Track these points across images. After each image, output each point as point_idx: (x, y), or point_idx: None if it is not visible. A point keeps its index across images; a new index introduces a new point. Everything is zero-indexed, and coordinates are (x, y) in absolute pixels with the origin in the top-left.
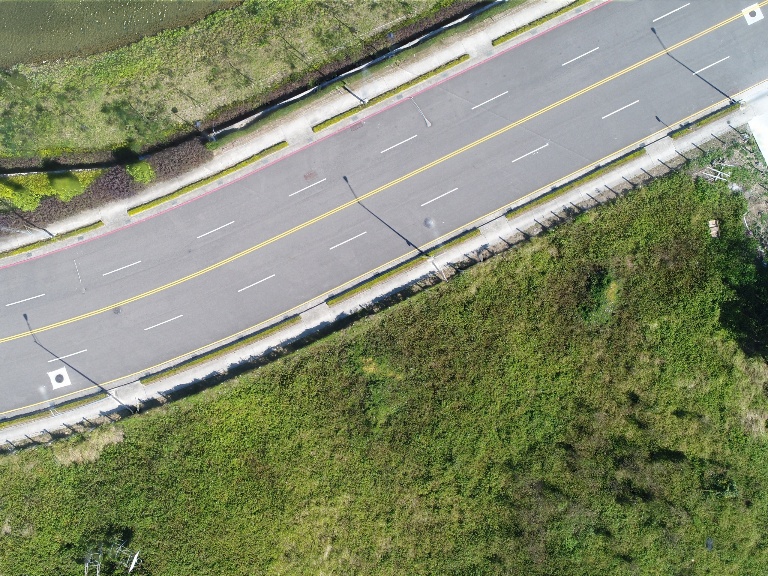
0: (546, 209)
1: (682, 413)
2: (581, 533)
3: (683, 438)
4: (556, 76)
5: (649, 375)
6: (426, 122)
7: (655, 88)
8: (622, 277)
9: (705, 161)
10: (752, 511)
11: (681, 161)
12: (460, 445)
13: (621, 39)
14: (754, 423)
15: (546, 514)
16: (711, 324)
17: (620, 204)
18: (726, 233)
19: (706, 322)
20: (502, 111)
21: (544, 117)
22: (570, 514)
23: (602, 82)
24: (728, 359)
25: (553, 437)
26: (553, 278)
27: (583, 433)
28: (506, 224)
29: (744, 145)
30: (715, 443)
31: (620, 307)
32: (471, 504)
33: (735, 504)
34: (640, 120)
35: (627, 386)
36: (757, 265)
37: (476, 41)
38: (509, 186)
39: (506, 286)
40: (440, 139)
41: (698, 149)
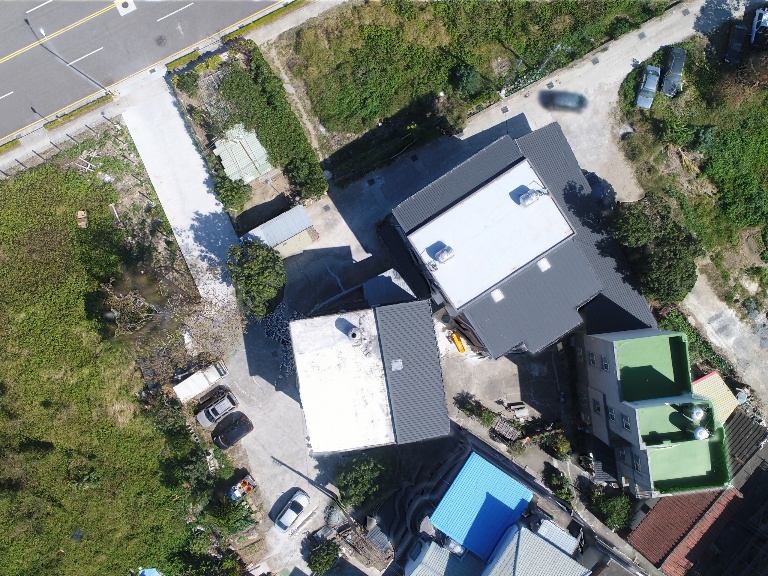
0: None
1: (48, 404)
2: None
3: (51, 429)
4: None
5: (17, 366)
6: None
7: (29, 79)
8: None
9: (75, 152)
10: (117, 502)
11: (55, 152)
12: None
13: None
14: (119, 414)
15: None
16: (78, 315)
17: None
18: (91, 224)
19: (71, 313)
20: None
21: None
22: None
23: None
24: (92, 350)
25: None
26: None
27: None
28: None
29: (116, 136)
30: (82, 434)
31: None
32: None
33: (100, 495)
34: (15, 111)
35: None
36: (123, 256)
37: None
38: None
39: None
40: None
41: (72, 140)
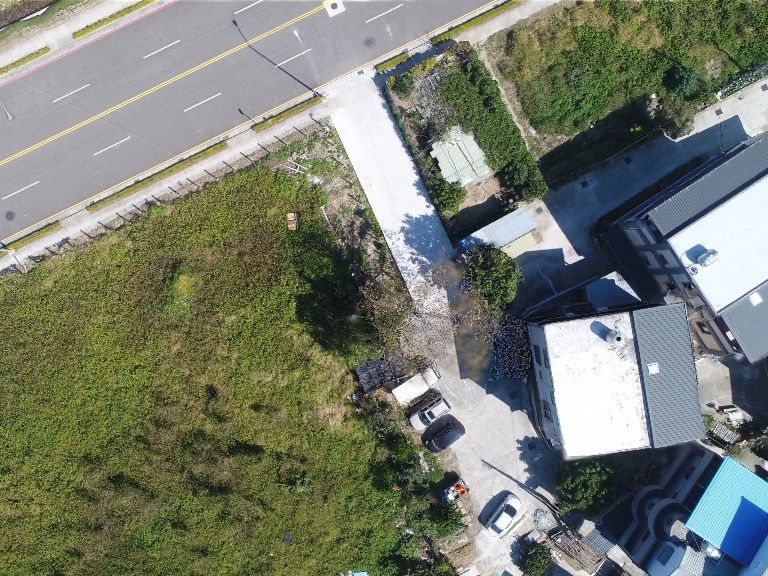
0: (128, 202)
1: (259, 407)
2: (158, 527)
3: (261, 432)
4: (137, 69)
5: (227, 369)
6: (7, 115)
7: (237, 81)
8: (198, 270)
9: (285, 154)
10: (328, 505)
11: (263, 154)
12: (40, 438)
13: (202, 32)
14: (331, 417)
15: (119, 508)
16: (288, 317)
17: (197, 197)
18: (302, 226)
19: (282, 315)
20: (83, 104)
21: (125, 110)
22: (146, 508)
23: (183, 75)
24: (304, 353)
25: (130, 431)
26: (130, 271)
27: (161, 427)
28: (88, 217)
29: (325, 138)
30: (293, 437)
31: (197, 300)
32: (50, 498)
33: (311, 498)
34: (223, 113)
35: (205, 380)
36: (334, 258)
37: (57, 34)
38: (91, 179)
39: (83, 279)
40: (21, 132)
41: (280, 142)
